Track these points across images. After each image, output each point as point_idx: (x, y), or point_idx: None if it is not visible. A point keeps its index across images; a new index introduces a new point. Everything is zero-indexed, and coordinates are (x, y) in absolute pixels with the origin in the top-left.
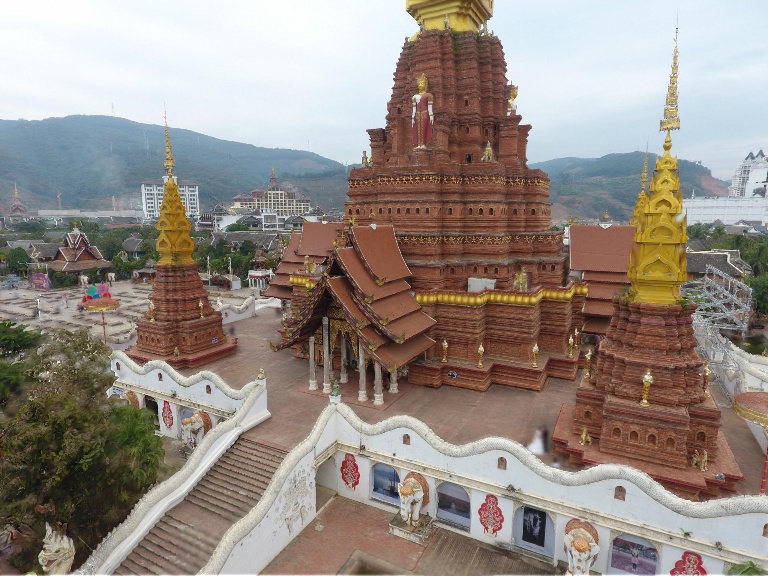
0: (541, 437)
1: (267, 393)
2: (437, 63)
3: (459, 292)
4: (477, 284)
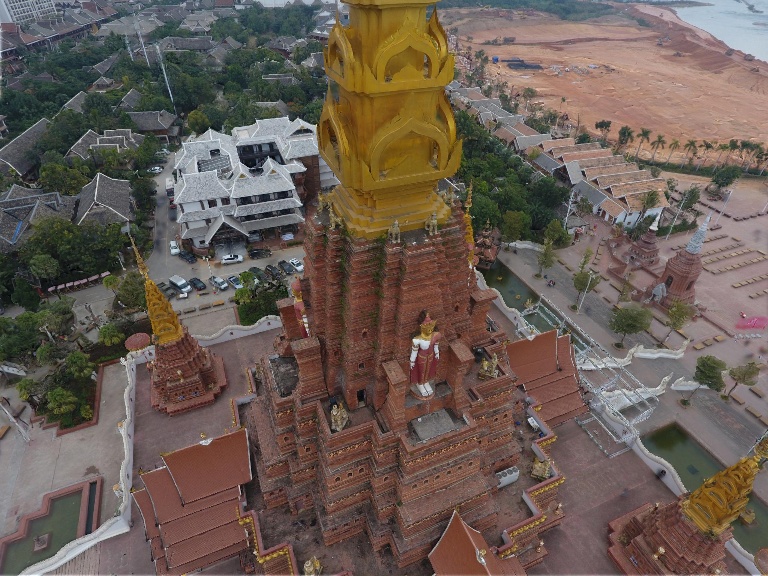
0: None
1: None
2: (436, 288)
3: (527, 523)
4: (505, 481)
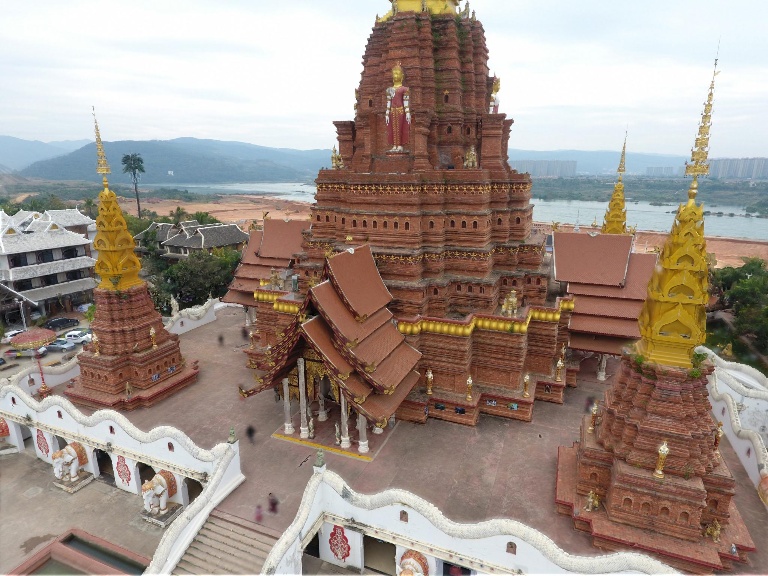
0: None
1: None
2: None
3: None
4: None
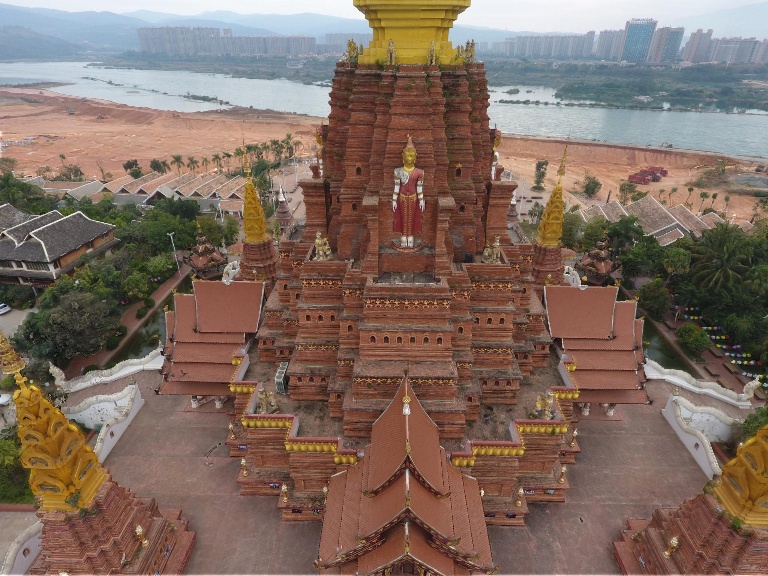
0: None
1: (645, 435)
2: None
3: None
4: None
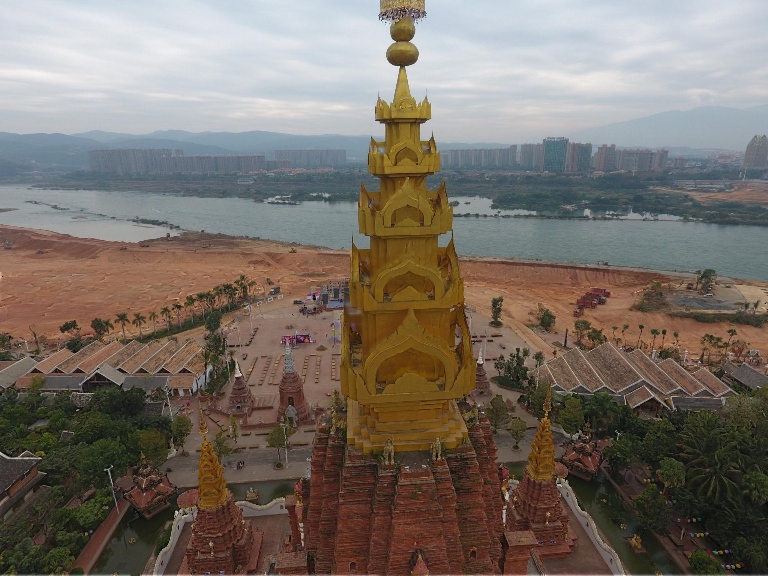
0: (559, 566)
1: None
2: None
3: None
4: None
